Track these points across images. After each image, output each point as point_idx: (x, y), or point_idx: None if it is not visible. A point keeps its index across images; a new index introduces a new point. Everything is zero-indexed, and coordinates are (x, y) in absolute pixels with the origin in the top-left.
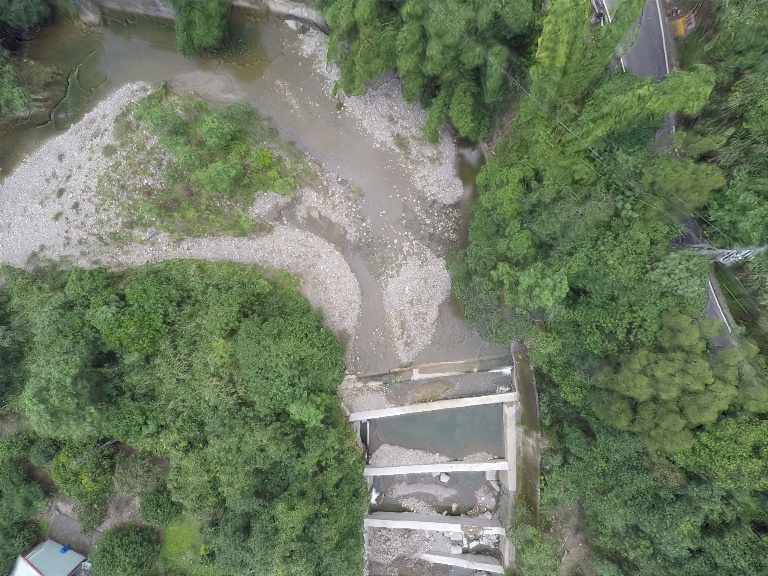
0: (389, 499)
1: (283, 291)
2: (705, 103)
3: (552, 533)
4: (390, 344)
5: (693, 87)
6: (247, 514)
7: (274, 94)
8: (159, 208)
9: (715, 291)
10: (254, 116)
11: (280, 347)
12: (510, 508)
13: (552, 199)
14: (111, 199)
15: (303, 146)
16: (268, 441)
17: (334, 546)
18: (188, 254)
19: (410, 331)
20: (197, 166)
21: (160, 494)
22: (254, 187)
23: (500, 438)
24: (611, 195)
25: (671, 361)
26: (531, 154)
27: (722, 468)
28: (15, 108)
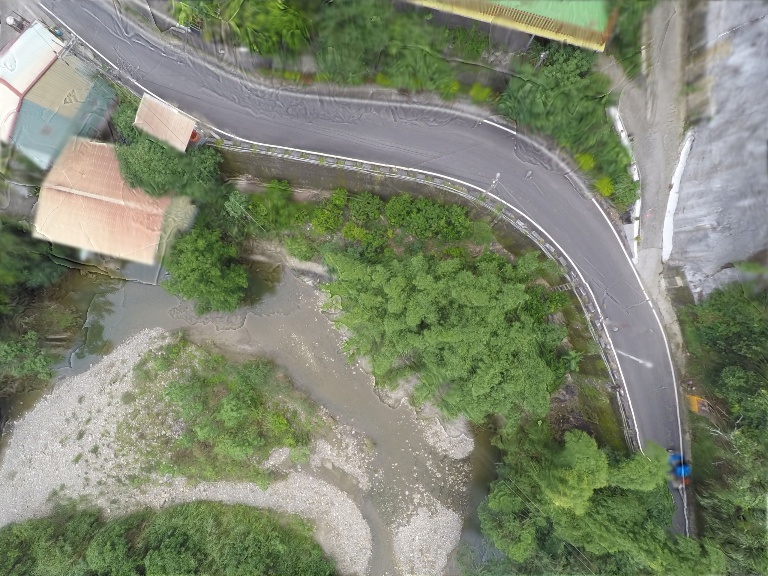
0: None
1: (297, 542)
2: None
3: None
4: None
5: None
6: None
7: (290, 347)
8: (177, 457)
9: None
10: (270, 374)
11: None
12: None
13: None
14: (130, 445)
15: (318, 398)
16: None
17: None
18: (204, 496)
19: None
20: (215, 439)
21: None
22: (270, 446)
23: None
24: None
25: None
26: (544, 503)
27: None
28: (38, 387)
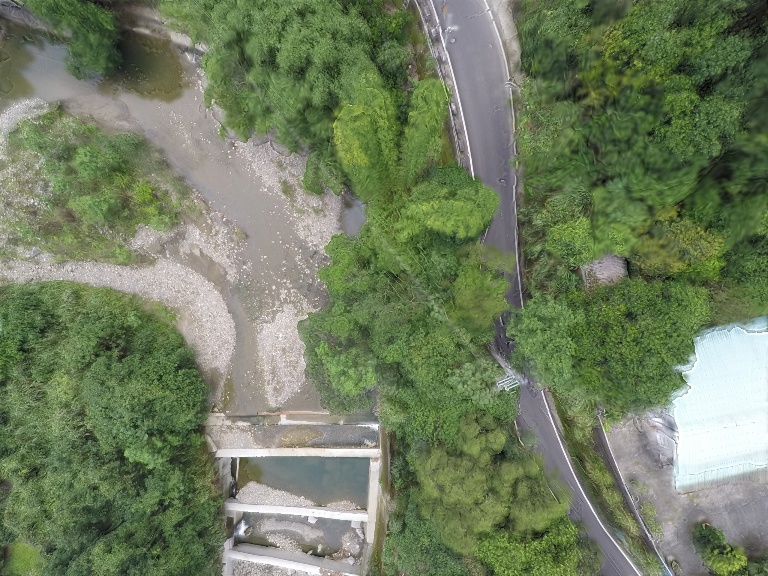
0: (257, 532)
1: (156, 325)
2: (468, 235)
3: None
4: (260, 388)
5: (453, 220)
6: (82, 544)
7: (168, 126)
8: None
9: (544, 391)
10: (143, 147)
11: (126, 389)
12: (367, 559)
13: (364, 291)
14: None
15: (192, 182)
16: (101, 480)
17: None
18: (72, 276)
19: (280, 378)
20: (73, 195)
21: None
22: (135, 219)
23: (365, 490)
24: (429, 292)
25: (455, 471)
26: None
27: None
28: None
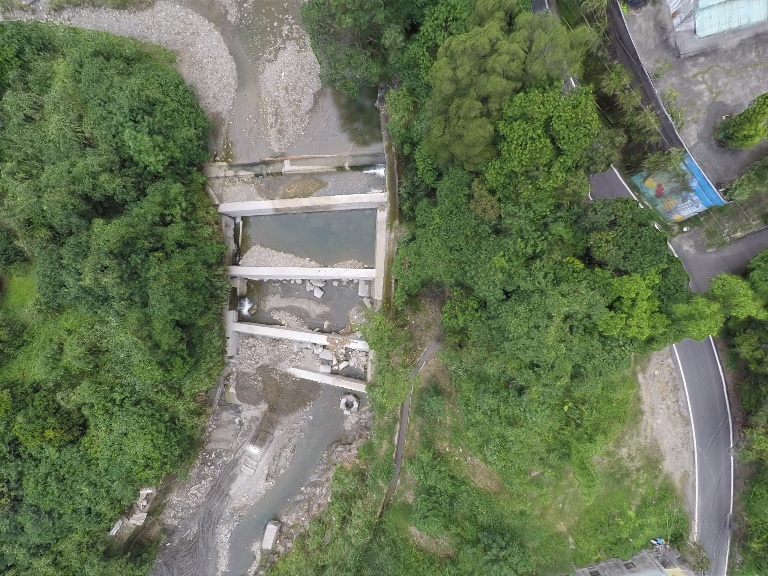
0: (262, 311)
1: (156, 62)
2: None
3: (405, 330)
4: (263, 132)
5: None
6: None
7: None
8: None
9: None
10: None
11: (125, 81)
12: None
13: None
14: None
15: None
16: (100, 167)
17: (162, 287)
18: None
19: (283, 118)
20: None
21: (1, 232)
22: None
23: (372, 248)
24: None
25: None
26: None
27: (518, 162)
28: None
